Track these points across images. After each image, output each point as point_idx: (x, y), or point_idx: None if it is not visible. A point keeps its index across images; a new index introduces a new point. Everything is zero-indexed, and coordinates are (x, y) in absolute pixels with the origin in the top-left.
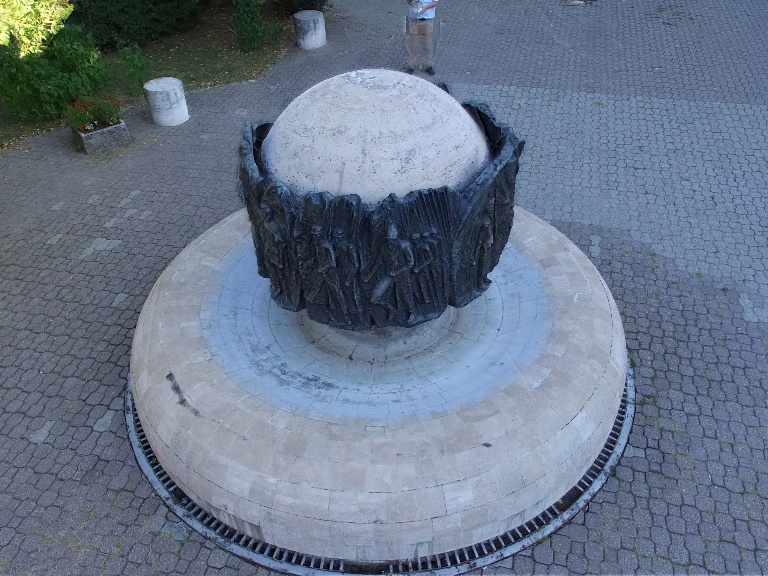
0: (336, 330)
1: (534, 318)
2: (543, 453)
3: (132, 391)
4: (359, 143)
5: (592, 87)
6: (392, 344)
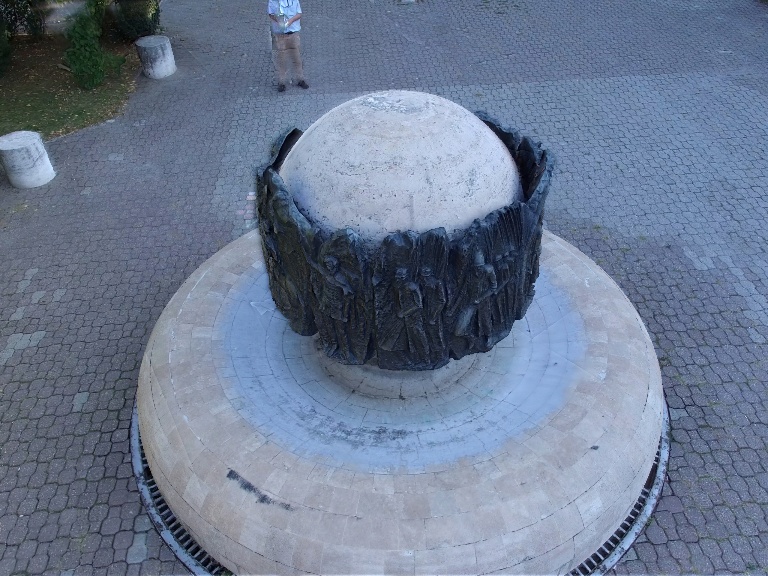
0: (373, 372)
1: (559, 312)
2: (639, 440)
3: (173, 504)
4: (421, 172)
5: (464, 80)
6: (436, 372)
